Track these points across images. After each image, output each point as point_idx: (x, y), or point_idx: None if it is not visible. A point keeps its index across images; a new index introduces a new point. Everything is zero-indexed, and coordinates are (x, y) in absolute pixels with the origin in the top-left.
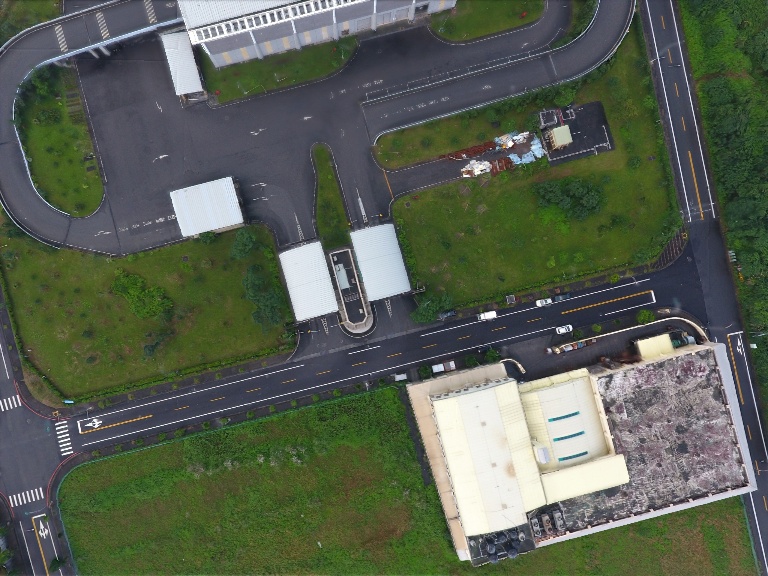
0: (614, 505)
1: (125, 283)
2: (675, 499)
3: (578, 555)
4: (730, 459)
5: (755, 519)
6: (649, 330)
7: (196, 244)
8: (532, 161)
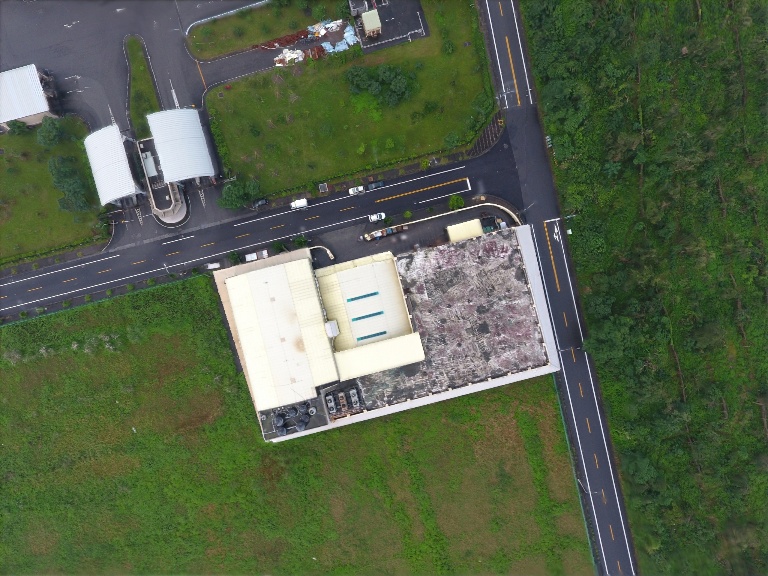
0: (414, 385)
1: None
2: (476, 379)
3: (390, 441)
4: (532, 339)
5: (570, 406)
6: (463, 217)
7: (11, 137)
8: (345, 49)
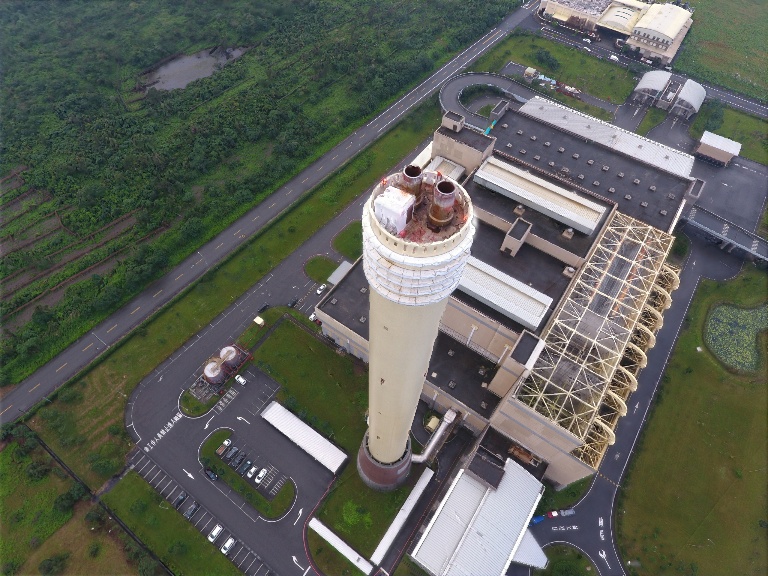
0: None
1: None
2: None
3: None
4: None
5: None
6: None
7: None
8: None
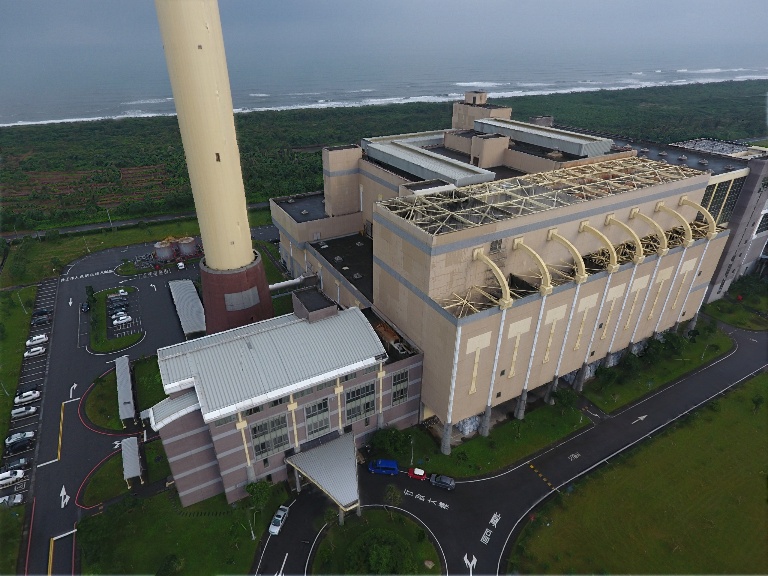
0: None
1: None
2: (739, 145)
3: None
4: None
5: None
6: None
7: None
8: None
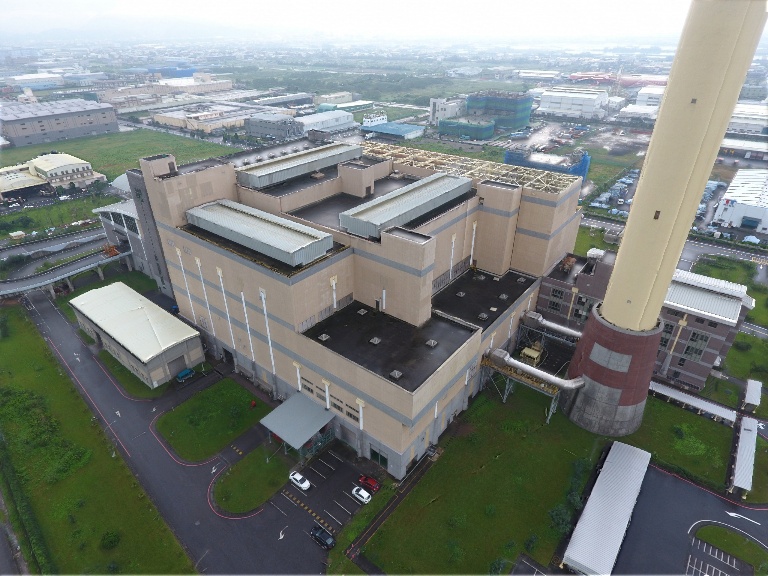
0: None
1: None
2: None
3: None
4: None
5: None
6: None
7: None
8: None
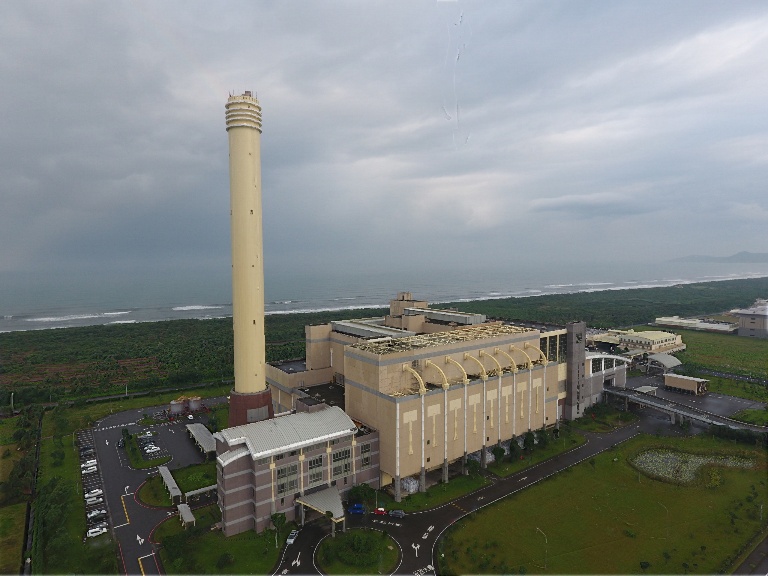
0: None
1: (765, 395)
2: None
3: None
4: None
5: None
6: None
7: None
8: None
